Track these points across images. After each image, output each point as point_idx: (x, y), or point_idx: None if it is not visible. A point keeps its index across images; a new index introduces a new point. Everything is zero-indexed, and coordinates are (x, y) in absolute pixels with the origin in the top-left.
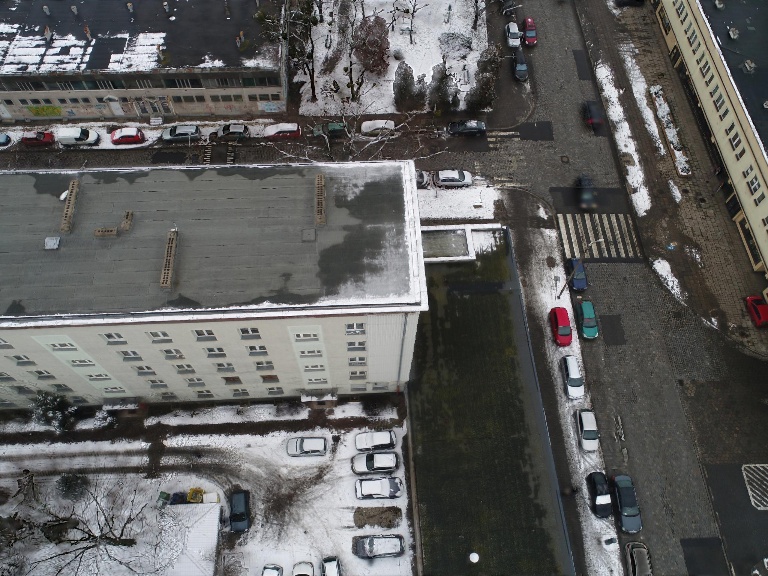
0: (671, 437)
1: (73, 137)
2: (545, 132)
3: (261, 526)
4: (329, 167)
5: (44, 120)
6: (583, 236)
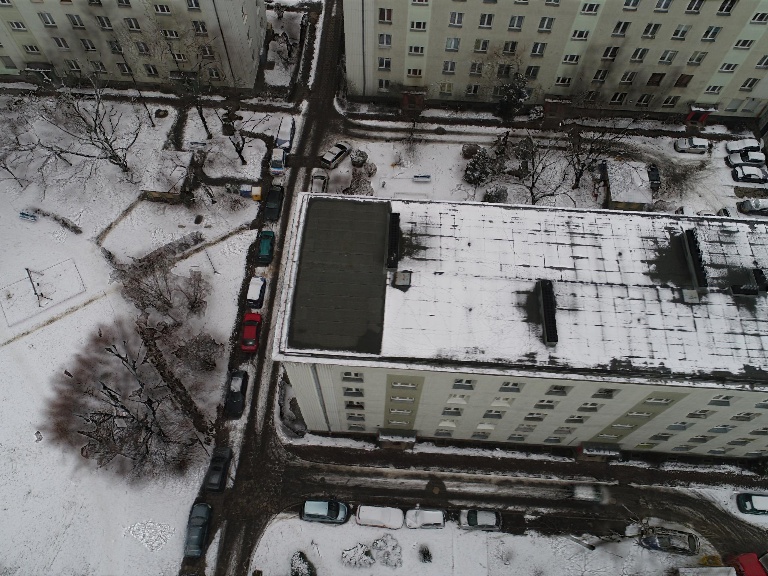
0: None
1: None
2: None
3: (666, 189)
4: None
5: None
6: None
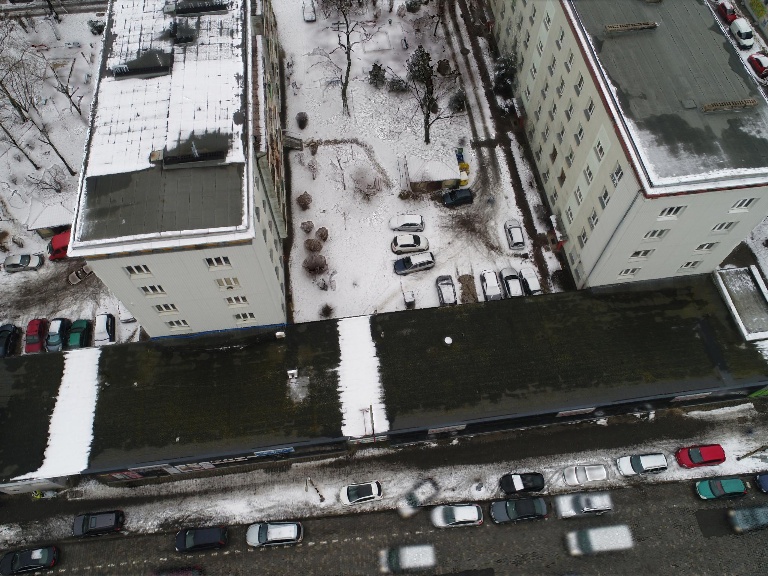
0: None
1: (740, 29)
2: None
3: (449, 214)
4: None
5: (749, 12)
6: None
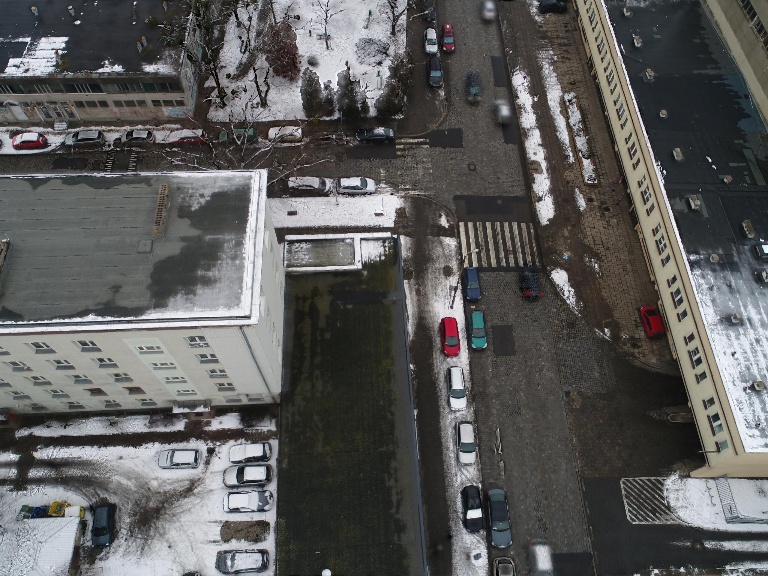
0: (552, 450)
1: None
2: (455, 139)
3: (125, 540)
4: (178, 176)
5: None
6: (482, 245)
